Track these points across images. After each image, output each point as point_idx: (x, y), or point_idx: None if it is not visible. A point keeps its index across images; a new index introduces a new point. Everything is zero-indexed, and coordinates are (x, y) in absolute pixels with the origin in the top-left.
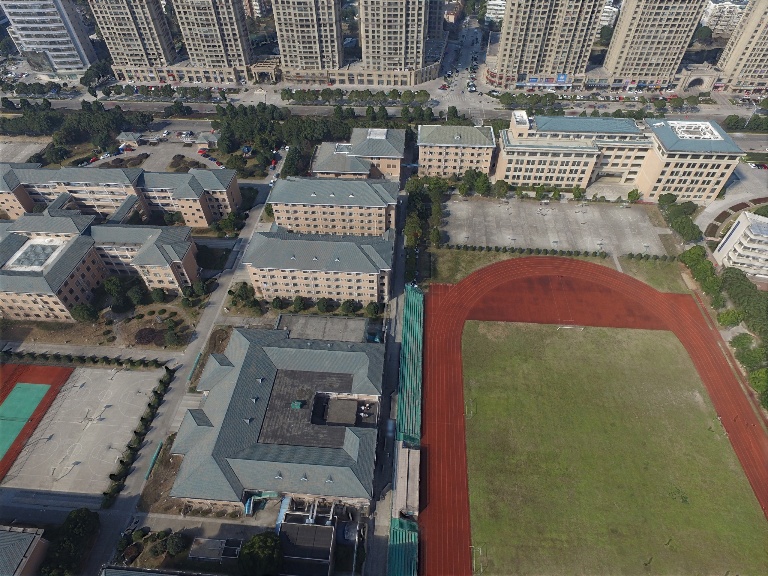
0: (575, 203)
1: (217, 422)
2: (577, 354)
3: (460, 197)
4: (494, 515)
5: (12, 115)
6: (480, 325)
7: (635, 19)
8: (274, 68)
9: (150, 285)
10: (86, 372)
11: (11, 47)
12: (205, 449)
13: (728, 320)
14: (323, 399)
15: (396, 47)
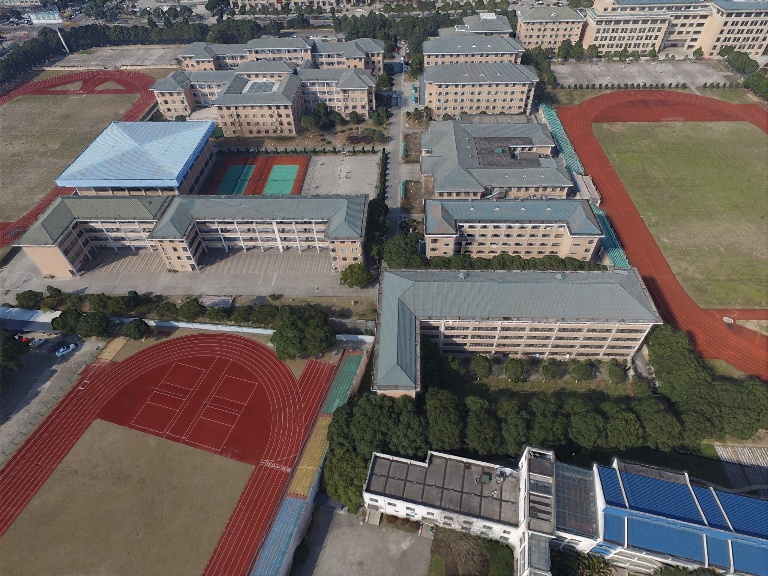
0: (651, 62)
1: (452, 154)
2: (681, 134)
3: (561, 59)
4: (651, 204)
5: None
6: (604, 124)
7: None
8: None
9: (345, 111)
10: (321, 158)
11: None
12: (450, 165)
13: None
14: None
15: None
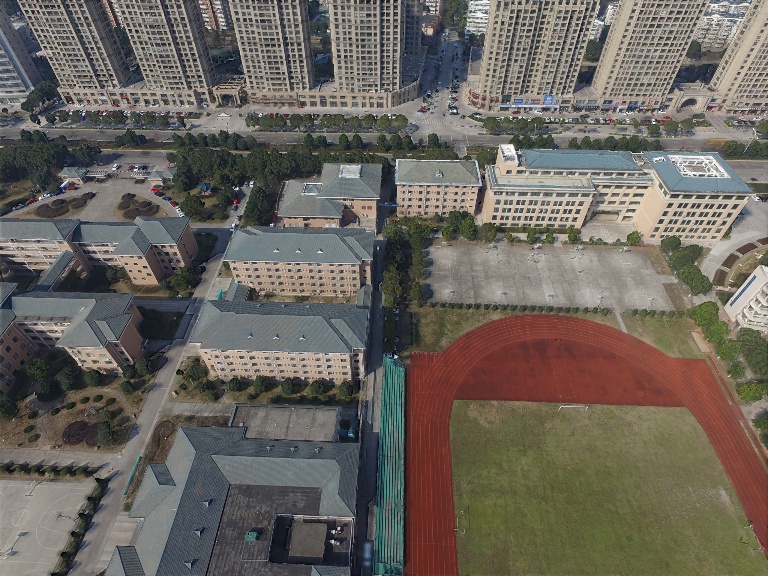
0: (570, 247)
1: (150, 570)
2: (583, 442)
3: (444, 243)
4: None
5: None
6: (470, 406)
7: (626, 38)
8: (238, 90)
9: (84, 365)
10: None
11: None
12: None
13: (750, 396)
14: (286, 520)
15: (371, 67)
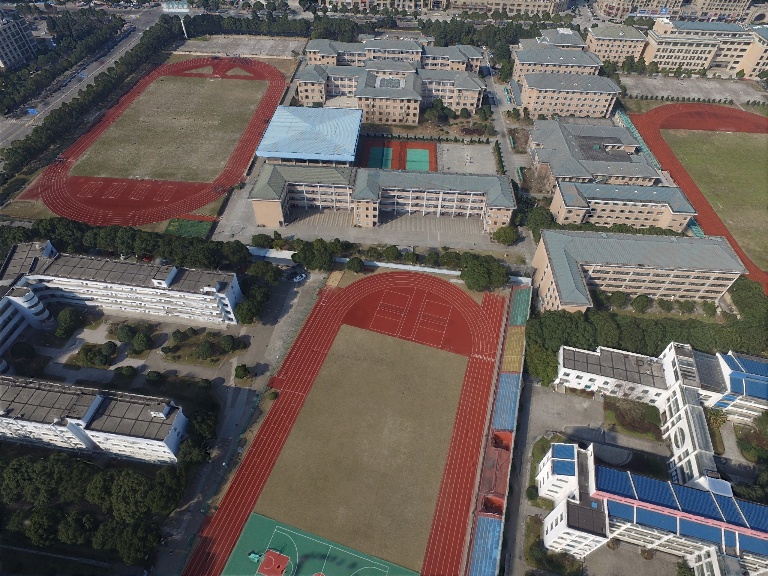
0: (701, 79)
1: (563, 148)
2: (733, 142)
3: (626, 72)
4: (716, 195)
5: None
6: (669, 130)
7: None
8: None
9: (456, 107)
10: (445, 145)
11: None
12: (564, 157)
13: None
14: None
15: None
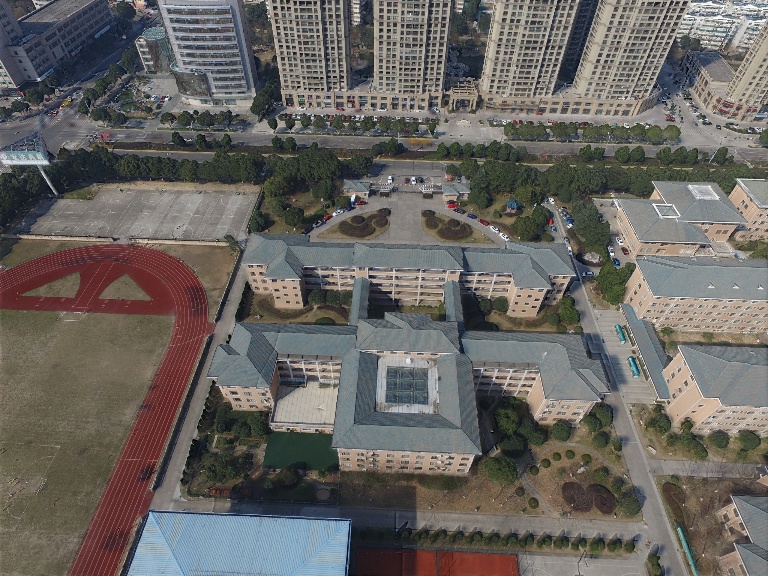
0: None
1: None
2: None
3: None
4: None
5: (184, 153)
6: None
7: None
8: None
9: (542, 416)
10: (537, 562)
11: (133, 62)
12: None
13: None
14: None
15: (630, 73)
